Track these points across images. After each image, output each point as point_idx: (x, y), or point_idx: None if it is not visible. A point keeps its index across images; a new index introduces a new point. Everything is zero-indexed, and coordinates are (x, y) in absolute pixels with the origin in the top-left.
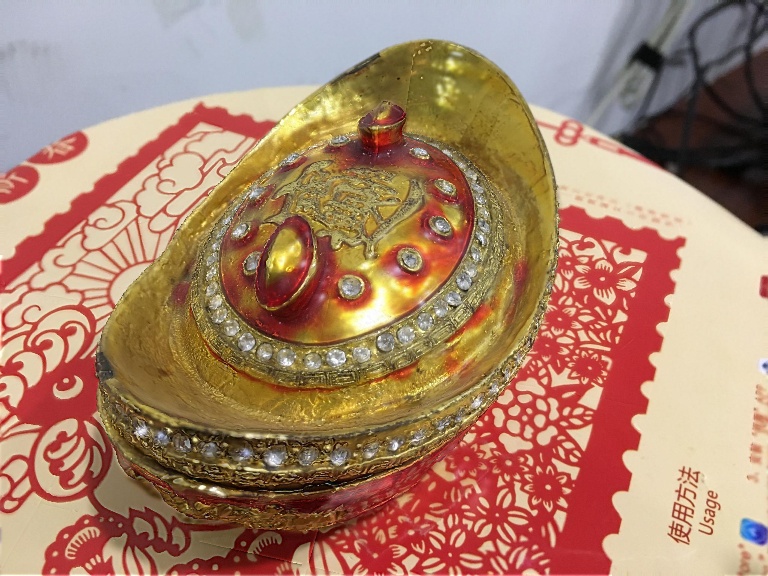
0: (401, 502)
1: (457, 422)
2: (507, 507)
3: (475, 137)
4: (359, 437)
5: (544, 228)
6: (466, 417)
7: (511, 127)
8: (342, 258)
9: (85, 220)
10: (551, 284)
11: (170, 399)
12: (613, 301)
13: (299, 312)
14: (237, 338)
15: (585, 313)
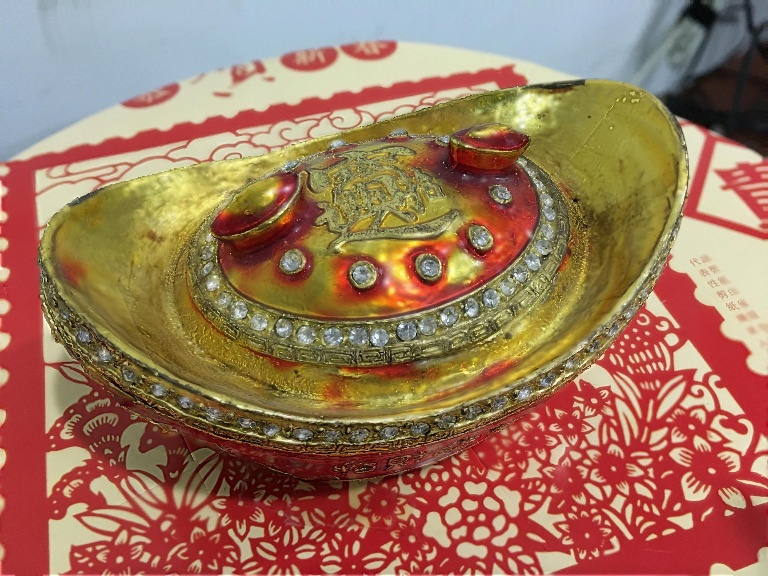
0: (300, 486)
1: (267, 434)
2: (368, 569)
3: (613, 218)
4: (146, 370)
5: (561, 346)
6: (284, 438)
7: (644, 228)
8: (313, 235)
9: (330, 112)
10: (512, 402)
11: (117, 253)
12: (695, 500)
13: (243, 254)
14: (207, 245)
15: (648, 485)
